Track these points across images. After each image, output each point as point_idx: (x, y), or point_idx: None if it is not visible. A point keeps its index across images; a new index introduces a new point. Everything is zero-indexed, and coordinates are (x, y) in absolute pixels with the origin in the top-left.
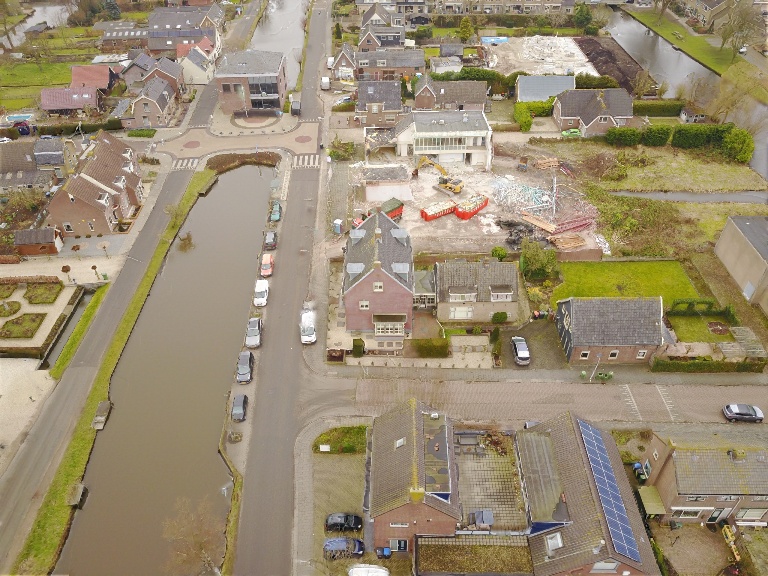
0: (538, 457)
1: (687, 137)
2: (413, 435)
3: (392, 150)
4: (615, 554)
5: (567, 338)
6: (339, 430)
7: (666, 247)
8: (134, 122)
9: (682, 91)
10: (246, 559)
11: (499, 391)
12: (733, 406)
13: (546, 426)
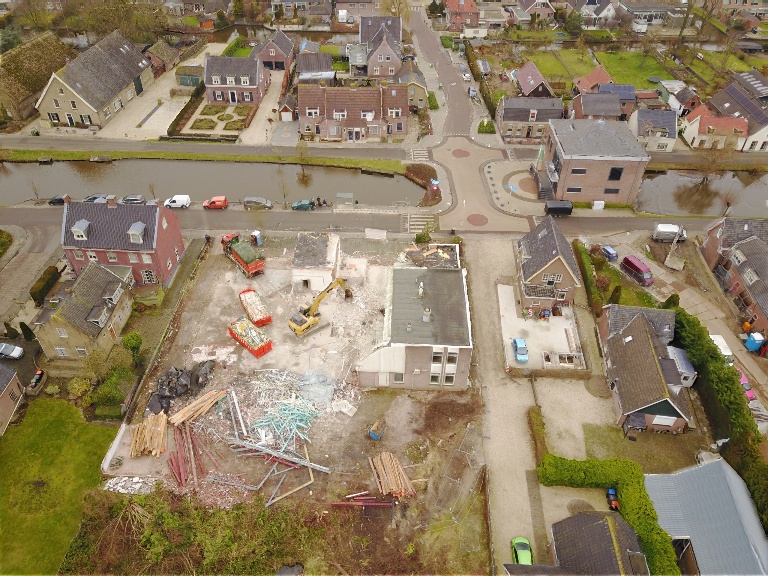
0: None
1: None
2: None
3: None
4: None
5: None
6: (3, 240)
7: None
8: None
9: None
10: None
11: None
12: None
13: None
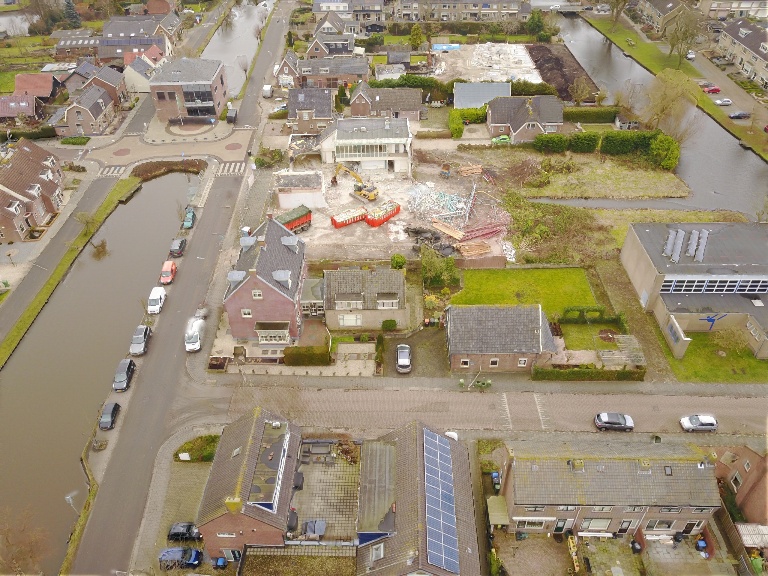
0: (379, 466)
1: (614, 144)
2: (248, 444)
3: (319, 157)
4: (427, 565)
5: (449, 346)
6: (203, 438)
7: (573, 254)
8: (68, 130)
9: (619, 98)
10: (83, 569)
11: (375, 399)
12: (603, 415)
13: (394, 435)
